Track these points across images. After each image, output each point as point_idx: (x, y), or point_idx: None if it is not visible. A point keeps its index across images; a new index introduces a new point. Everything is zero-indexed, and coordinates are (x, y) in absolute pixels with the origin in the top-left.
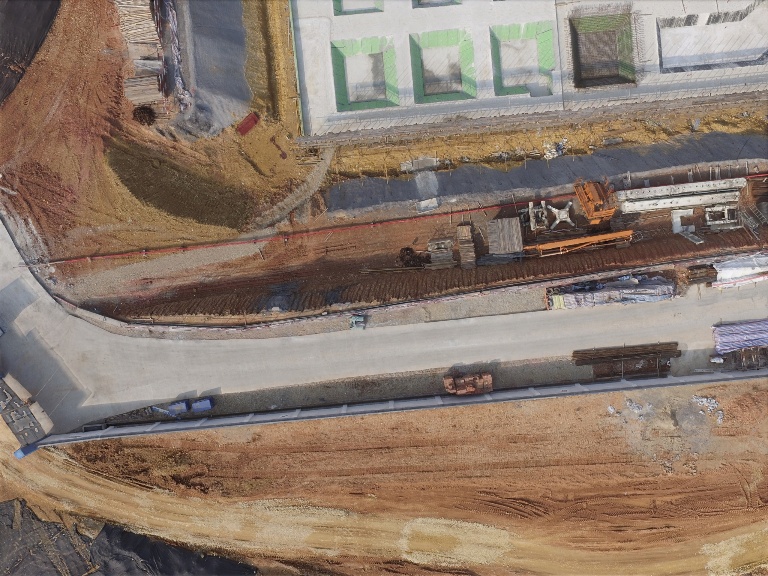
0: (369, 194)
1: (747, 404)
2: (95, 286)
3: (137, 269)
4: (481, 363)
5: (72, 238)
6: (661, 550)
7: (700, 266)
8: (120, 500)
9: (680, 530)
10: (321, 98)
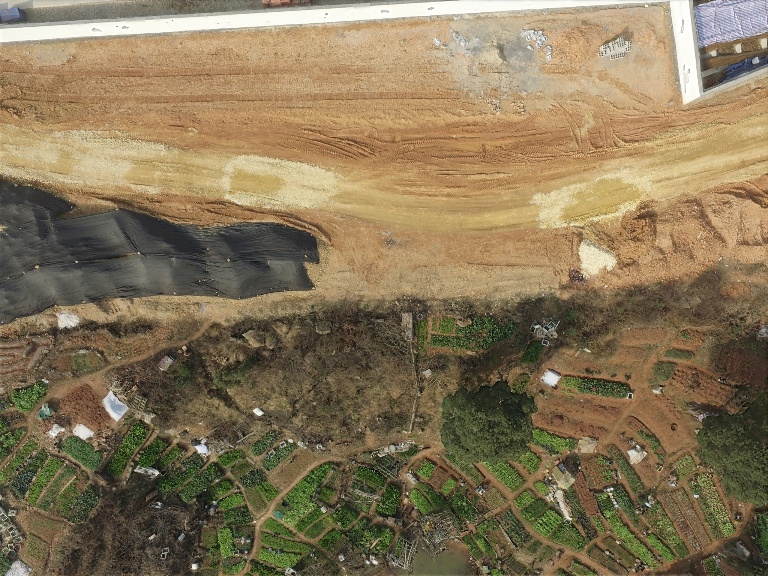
0: None
1: (575, 36)
2: None
3: None
4: None
5: None
6: (491, 199)
7: None
8: None
9: (510, 177)
10: None
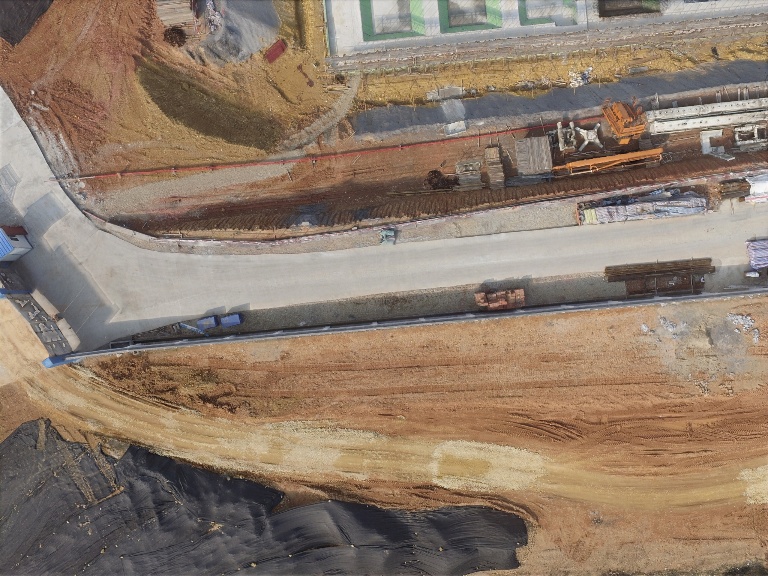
0: (396, 119)
1: None
2: (124, 202)
3: (166, 187)
4: (512, 279)
5: (102, 154)
6: (698, 476)
7: (733, 180)
8: (146, 421)
9: (717, 454)
10: (348, 28)
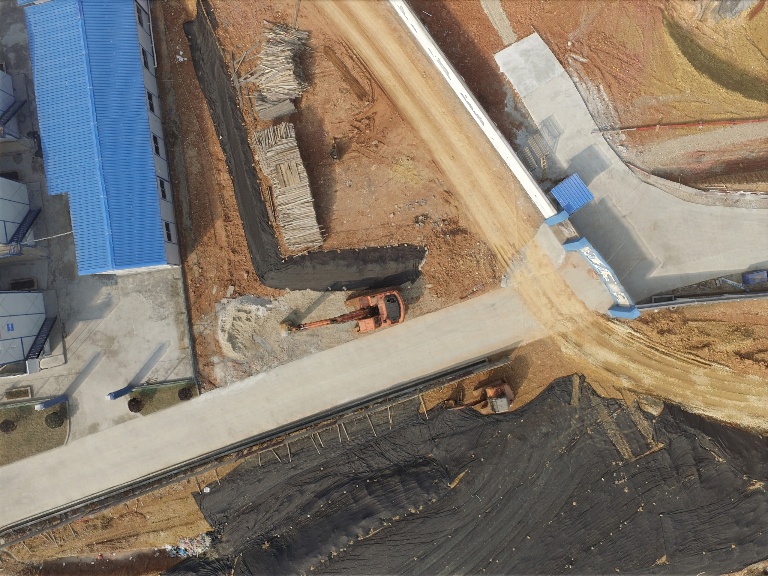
0: None
1: None
2: (660, 155)
3: (693, 141)
4: None
5: (638, 107)
6: None
7: None
8: (677, 377)
9: None
10: None
